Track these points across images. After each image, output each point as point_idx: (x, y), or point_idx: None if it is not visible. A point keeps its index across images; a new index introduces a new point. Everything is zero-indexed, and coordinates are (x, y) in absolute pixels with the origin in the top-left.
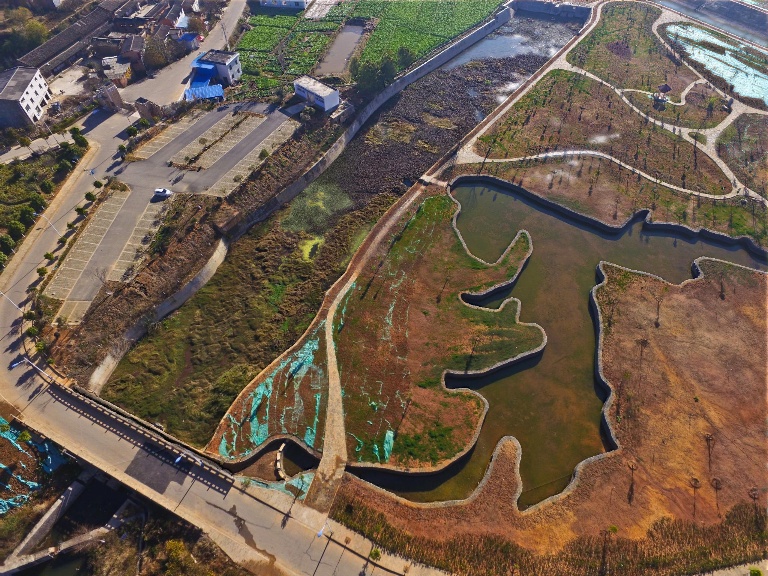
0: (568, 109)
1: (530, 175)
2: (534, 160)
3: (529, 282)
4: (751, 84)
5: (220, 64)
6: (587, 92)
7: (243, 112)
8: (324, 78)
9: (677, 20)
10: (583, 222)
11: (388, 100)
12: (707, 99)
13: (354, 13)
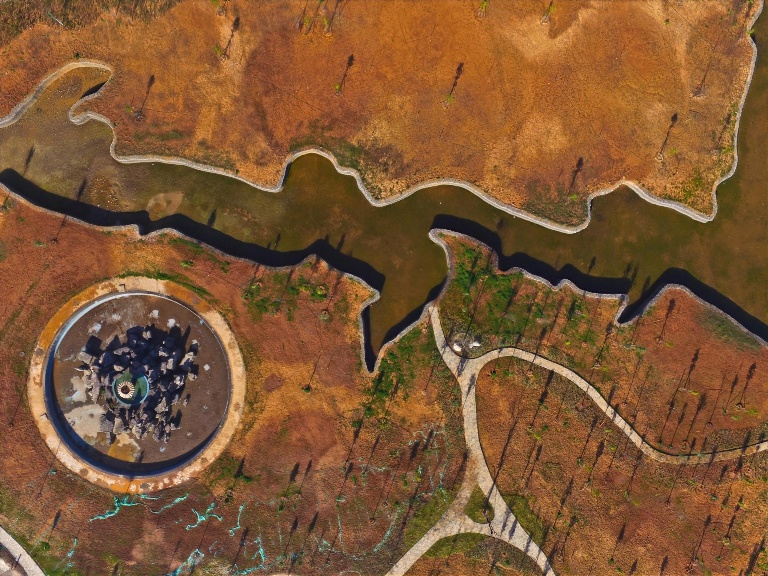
0: None
1: None
2: (766, 437)
3: None
4: None
5: None
6: None
7: None
8: None
9: None
10: None
11: None
12: None
13: None
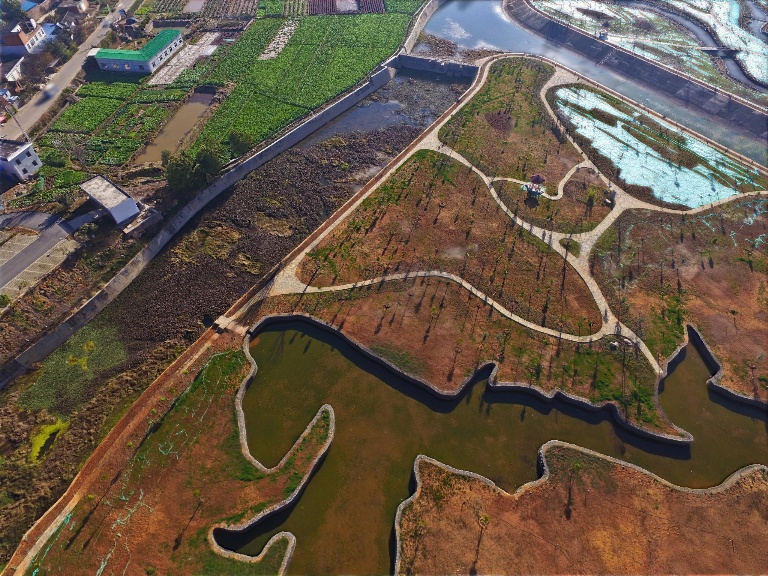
0: (424, 208)
1: (356, 312)
2: (366, 288)
3: (318, 495)
4: (641, 166)
5: (1, 160)
6: (451, 182)
7: (11, 228)
8: (141, 170)
9: (570, 81)
10: (412, 383)
11: (218, 195)
12: (588, 189)
13: (209, 77)
